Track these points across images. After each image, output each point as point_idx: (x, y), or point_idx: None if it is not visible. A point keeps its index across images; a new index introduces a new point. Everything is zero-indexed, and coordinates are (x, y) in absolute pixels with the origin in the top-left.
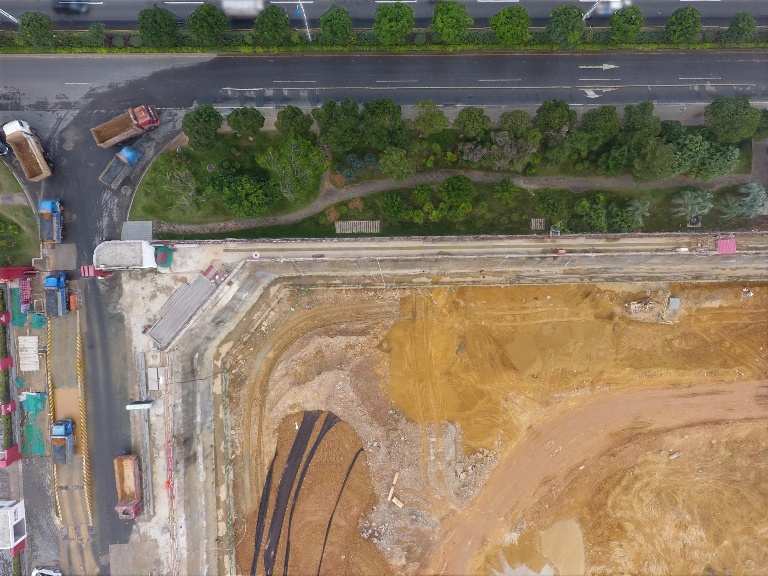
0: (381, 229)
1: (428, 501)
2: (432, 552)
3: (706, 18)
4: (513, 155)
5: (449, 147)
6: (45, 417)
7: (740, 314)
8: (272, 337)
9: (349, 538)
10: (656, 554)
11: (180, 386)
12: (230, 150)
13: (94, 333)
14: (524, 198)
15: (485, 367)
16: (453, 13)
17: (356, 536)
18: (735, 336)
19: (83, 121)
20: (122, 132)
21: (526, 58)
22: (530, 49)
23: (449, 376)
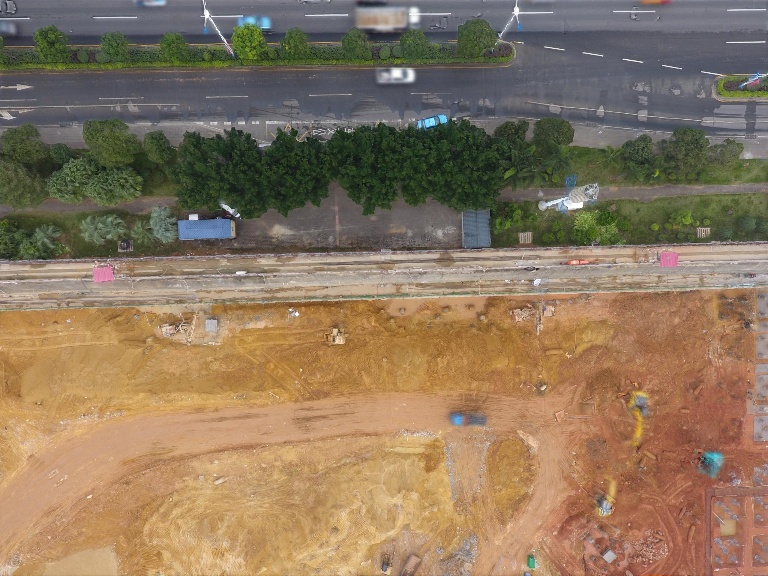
0: None
1: None
2: None
3: None
4: None
5: None
6: None
7: (286, 335)
8: None
9: None
10: None
11: None
12: None
13: None
14: None
15: None
16: None
17: None
18: (279, 357)
19: None
20: None
21: None
22: None
23: None
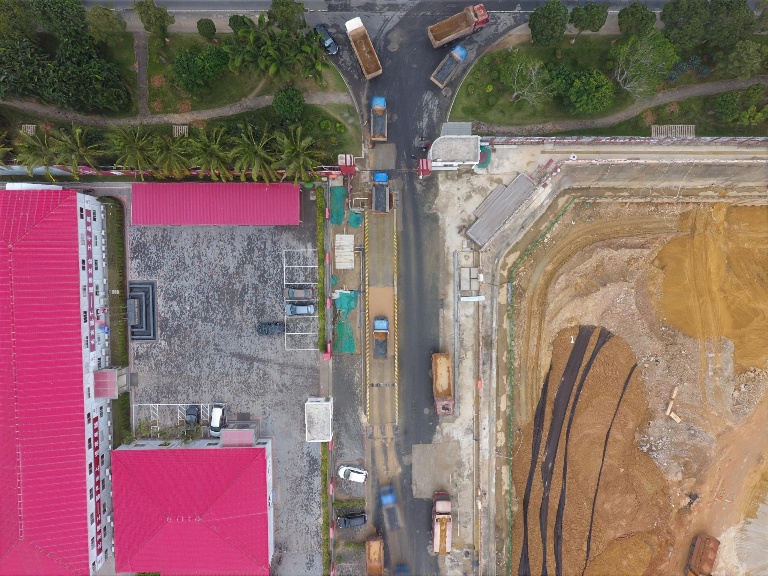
0: (696, 133)
1: (704, 417)
2: (708, 468)
3: None
4: None
5: None
6: (356, 315)
7: None
8: (552, 250)
9: (626, 452)
10: None
11: (490, 287)
12: (555, 52)
13: (409, 232)
14: None
15: (755, 287)
16: None
17: (634, 450)
18: None
19: (409, 23)
20: (453, 32)
21: None
22: None
23: (725, 293)
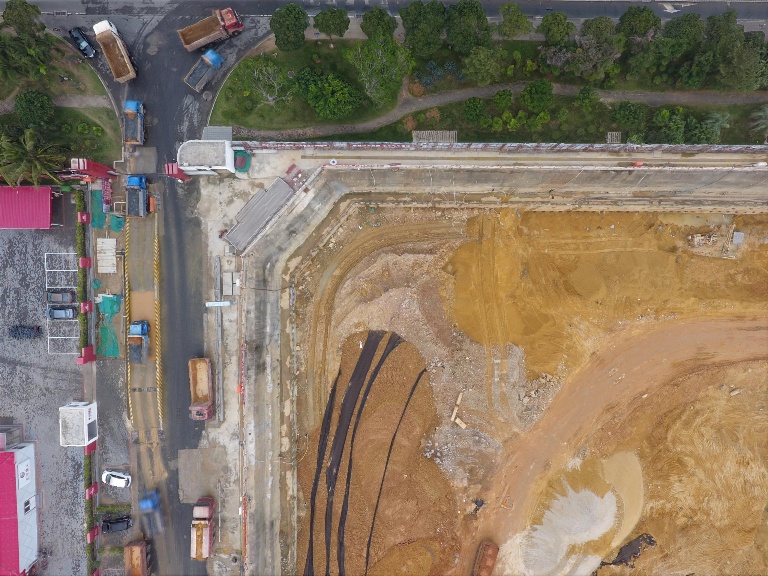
0: (457, 139)
1: (491, 423)
2: (494, 475)
3: None
4: (598, 58)
5: (527, 58)
6: (120, 320)
7: None
8: (339, 255)
9: (411, 458)
10: (716, 490)
11: (254, 292)
12: (312, 56)
13: (171, 237)
14: (601, 111)
15: (549, 293)
16: None
17: (418, 456)
18: None
19: (168, 26)
20: None
21: None
22: None
23: (514, 299)
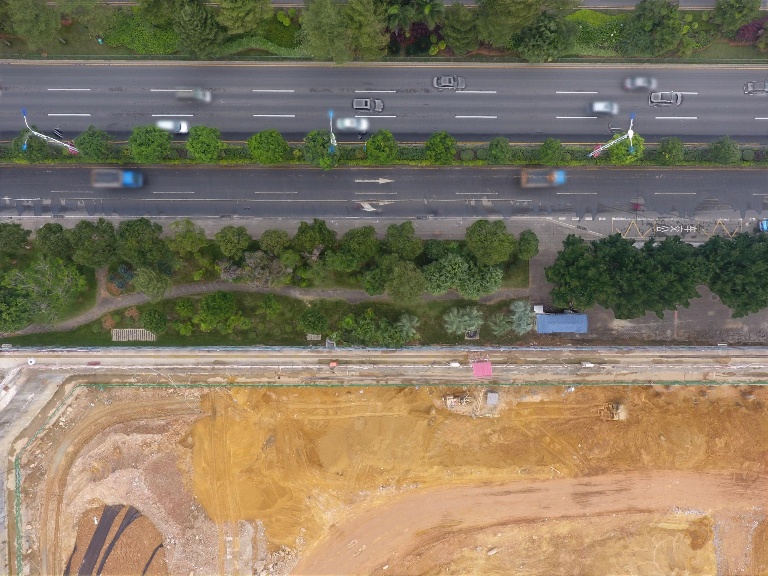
0: (157, 337)
1: None
2: None
3: (482, 135)
4: (266, 276)
5: (224, 258)
6: None
7: (561, 409)
8: (72, 432)
9: None
10: None
11: None
12: (5, 259)
13: None
14: (300, 309)
15: (290, 463)
16: (203, 139)
17: None
18: (555, 431)
19: None
20: None
21: (302, 171)
22: (304, 164)
23: (250, 473)
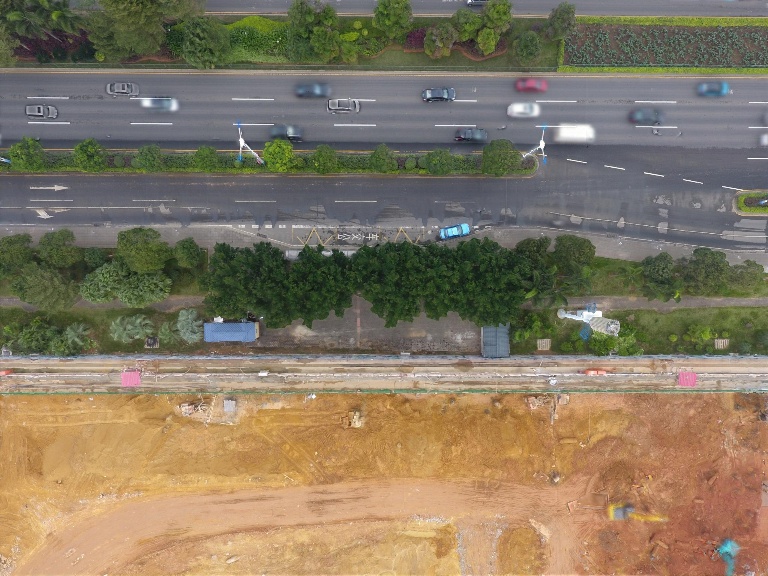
0: None
1: None
2: None
3: (157, 141)
4: None
5: None
6: None
7: (302, 416)
8: None
9: None
10: None
11: None
12: None
13: None
14: None
15: (10, 471)
16: None
17: None
18: (295, 439)
19: None
20: None
21: None
22: None
23: None
